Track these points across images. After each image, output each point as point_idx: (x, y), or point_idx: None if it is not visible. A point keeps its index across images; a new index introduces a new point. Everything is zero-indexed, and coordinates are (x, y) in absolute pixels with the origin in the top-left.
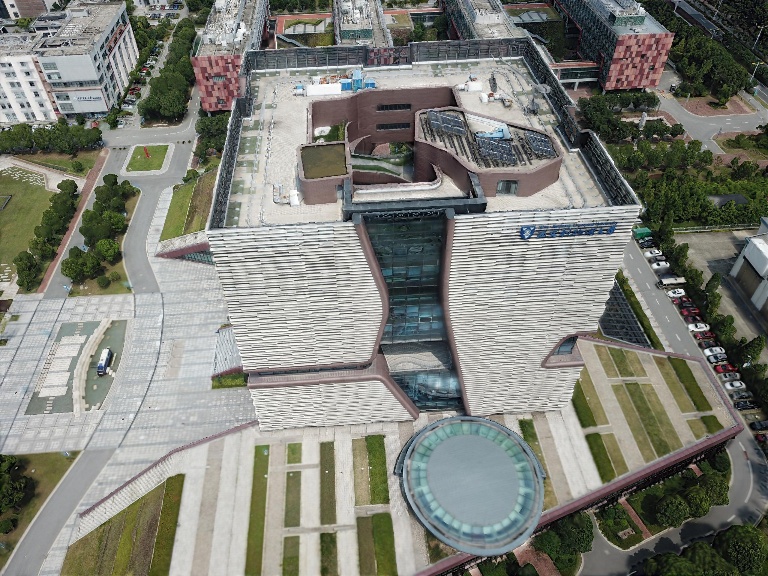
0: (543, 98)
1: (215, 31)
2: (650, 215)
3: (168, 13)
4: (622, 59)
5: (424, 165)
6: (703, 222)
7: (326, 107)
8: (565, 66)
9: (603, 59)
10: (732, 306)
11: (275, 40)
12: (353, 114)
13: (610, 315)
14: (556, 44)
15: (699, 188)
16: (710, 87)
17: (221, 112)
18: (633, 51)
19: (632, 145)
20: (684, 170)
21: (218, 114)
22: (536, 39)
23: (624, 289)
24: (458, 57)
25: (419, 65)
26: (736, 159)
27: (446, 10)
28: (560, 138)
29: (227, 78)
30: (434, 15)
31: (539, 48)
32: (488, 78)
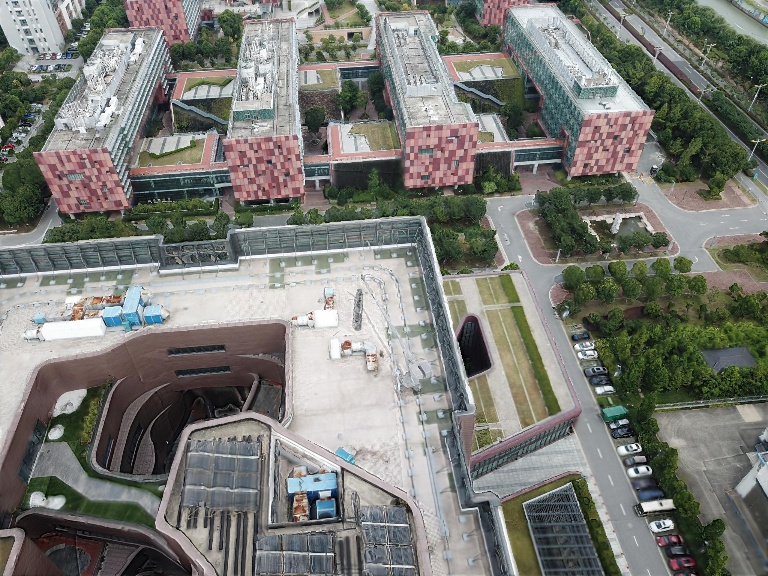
0: (435, 346)
1: (69, 115)
2: (625, 386)
3: (58, 64)
4: (590, 141)
5: (183, 557)
6: (696, 392)
7: (70, 368)
8: (520, 146)
9: (567, 138)
10: (741, 549)
11: (171, 107)
12: (125, 368)
13: (568, 575)
14: (511, 112)
15: (690, 338)
16: (699, 169)
17: (86, 213)
18: (603, 132)
19: (603, 259)
20: (670, 303)
21: (84, 215)
22: (489, 100)
23: (589, 520)
24: (313, 247)
25: (251, 260)
26: (737, 290)
27: (381, 65)
28: (448, 468)
29: (85, 176)
30: (368, 70)
31: (490, 119)
32: (354, 292)
